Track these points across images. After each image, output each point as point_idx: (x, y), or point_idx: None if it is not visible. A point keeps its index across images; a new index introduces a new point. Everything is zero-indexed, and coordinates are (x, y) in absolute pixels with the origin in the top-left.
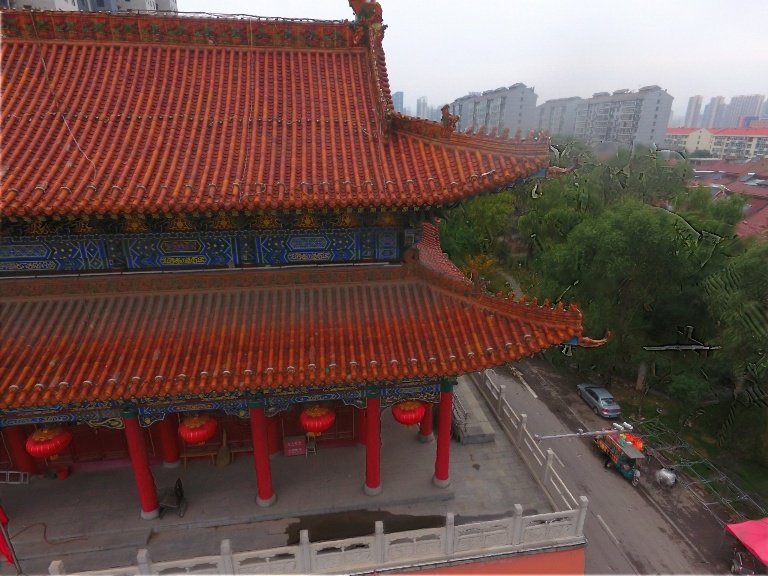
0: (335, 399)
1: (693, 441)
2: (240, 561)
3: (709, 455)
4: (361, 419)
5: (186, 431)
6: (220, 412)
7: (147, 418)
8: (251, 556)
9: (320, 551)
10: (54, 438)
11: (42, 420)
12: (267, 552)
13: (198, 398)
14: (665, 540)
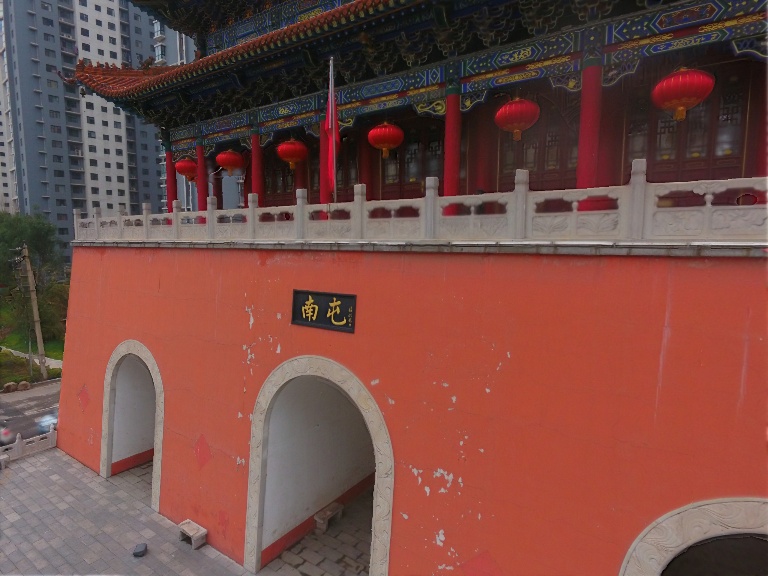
0: (719, 41)
1: None
2: (537, 204)
3: None
4: (758, 175)
5: (503, 106)
6: (545, 86)
7: (468, 99)
8: (553, 195)
9: (664, 198)
10: (389, 125)
11: (385, 106)
12: (576, 190)
13: (523, 64)
14: None
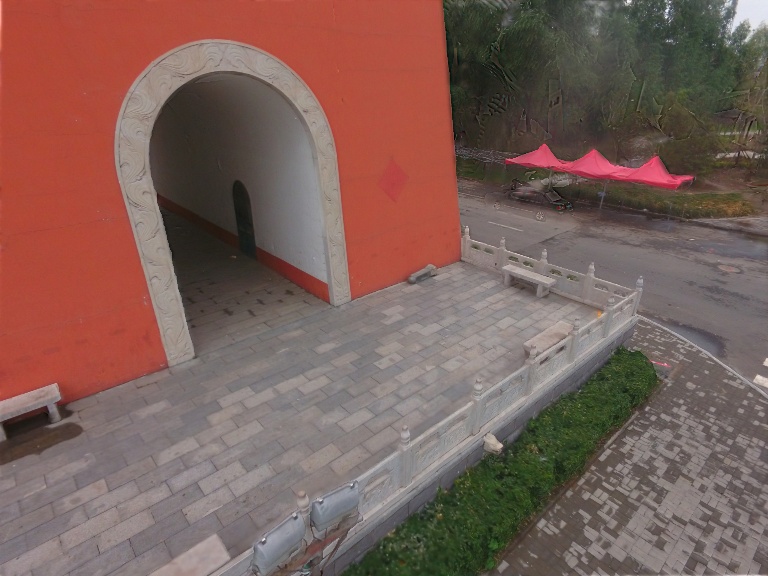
0: None
1: (458, 167)
2: None
3: (472, 169)
4: None
5: None
6: None
7: None
8: None
9: None
10: None
11: None
12: None
13: None
14: (463, 199)
